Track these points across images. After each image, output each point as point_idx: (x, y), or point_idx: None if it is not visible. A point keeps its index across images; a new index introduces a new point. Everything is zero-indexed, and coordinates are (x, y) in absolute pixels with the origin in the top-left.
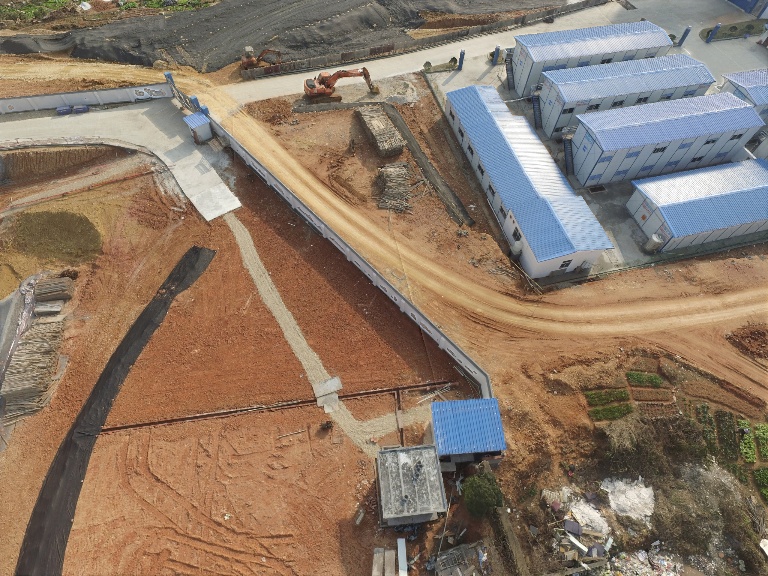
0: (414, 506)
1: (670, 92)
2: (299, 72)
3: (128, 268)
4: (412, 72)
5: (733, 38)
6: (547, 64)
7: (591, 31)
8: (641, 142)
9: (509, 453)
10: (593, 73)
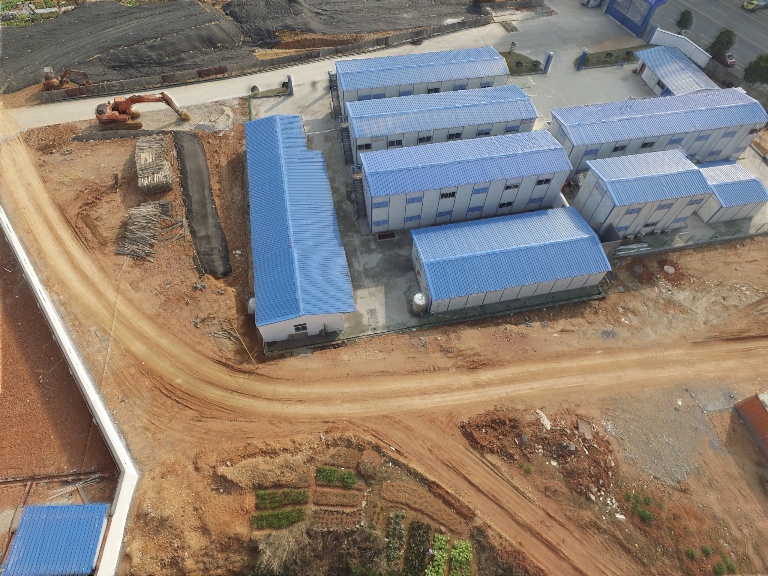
0: None
1: (486, 128)
2: (110, 95)
3: None
4: (239, 96)
5: (608, 66)
6: (361, 93)
7: (423, 57)
8: (419, 187)
9: (128, 570)
10: (401, 105)
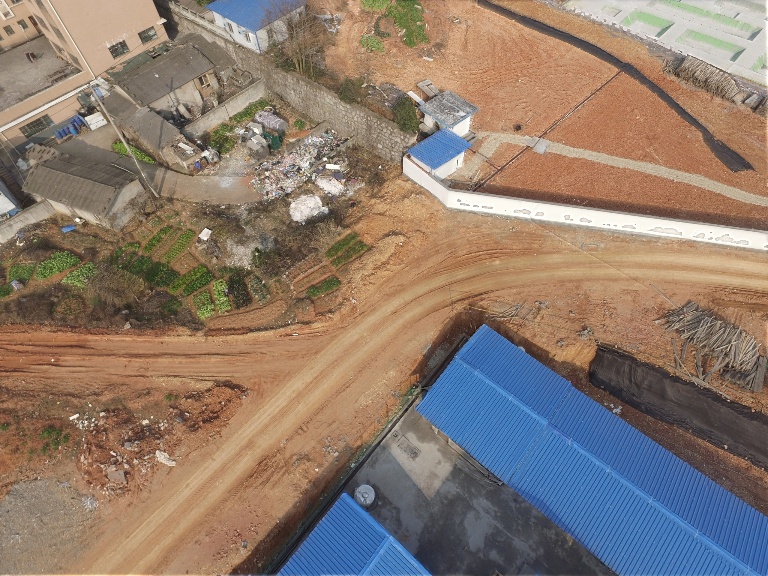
0: (437, 101)
1: None
2: None
3: (762, 139)
4: None
5: None
6: None
7: None
8: None
9: None
10: None
